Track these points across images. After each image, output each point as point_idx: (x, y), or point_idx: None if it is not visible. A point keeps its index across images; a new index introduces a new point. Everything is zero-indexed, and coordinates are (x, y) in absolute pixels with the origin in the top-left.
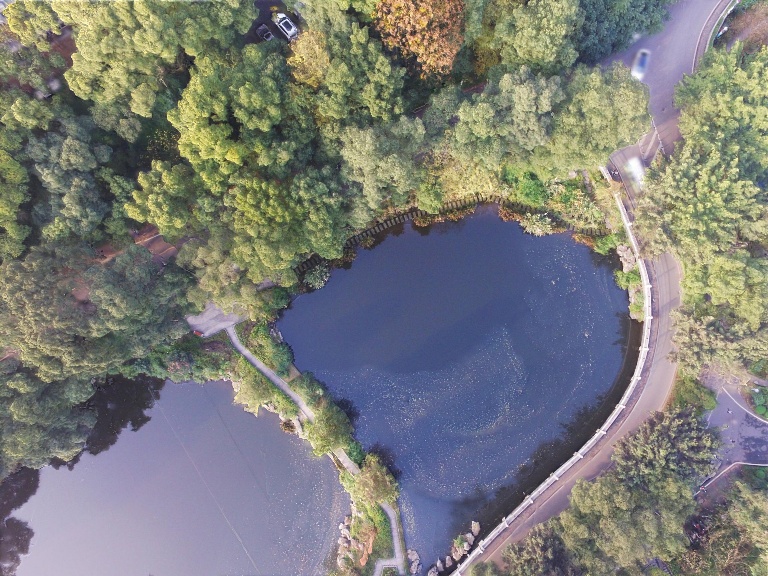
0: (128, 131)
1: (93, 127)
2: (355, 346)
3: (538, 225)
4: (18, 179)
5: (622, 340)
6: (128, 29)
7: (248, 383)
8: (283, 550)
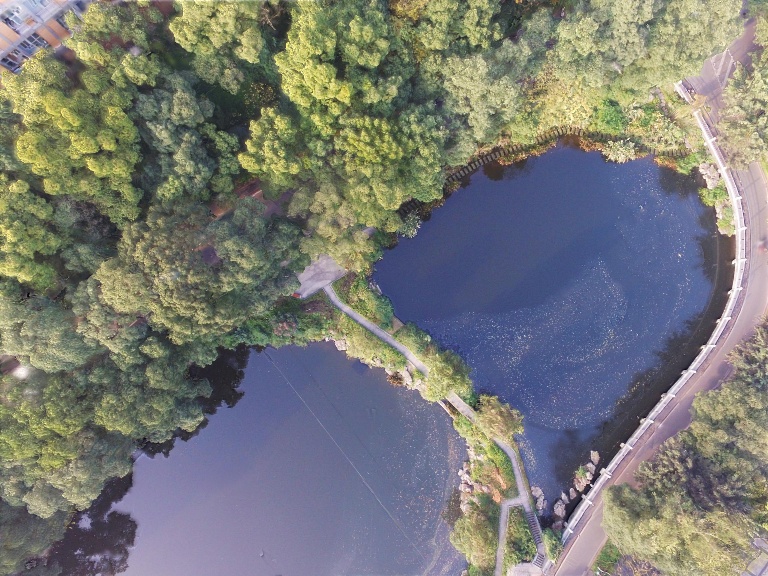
0: (233, 82)
1: (195, 82)
2: (454, 291)
3: (622, 151)
4: (131, 138)
5: (704, 262)
6: None
7: (361, 334)
8: (405, 503)
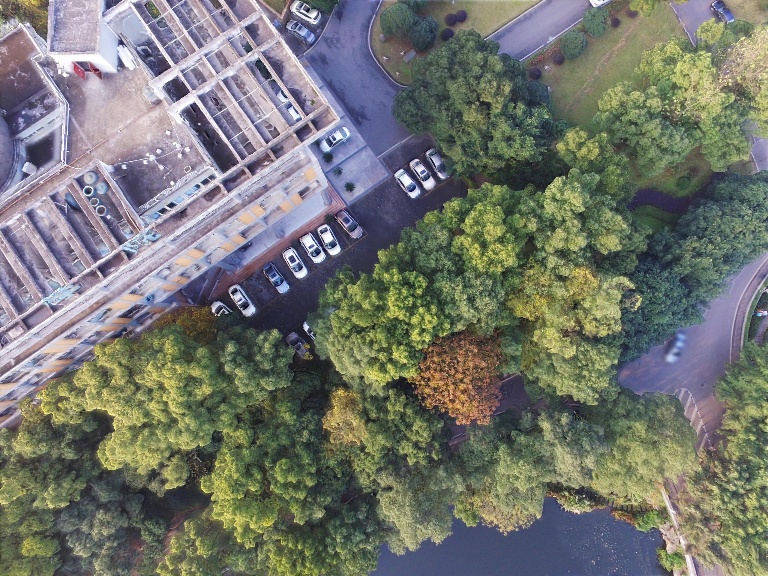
0: (160, 489)
1: (125, 480)
2: None
3: (576, 507)
4: (49, 555)
5: None
6: (163, 422)
7: None
8: None
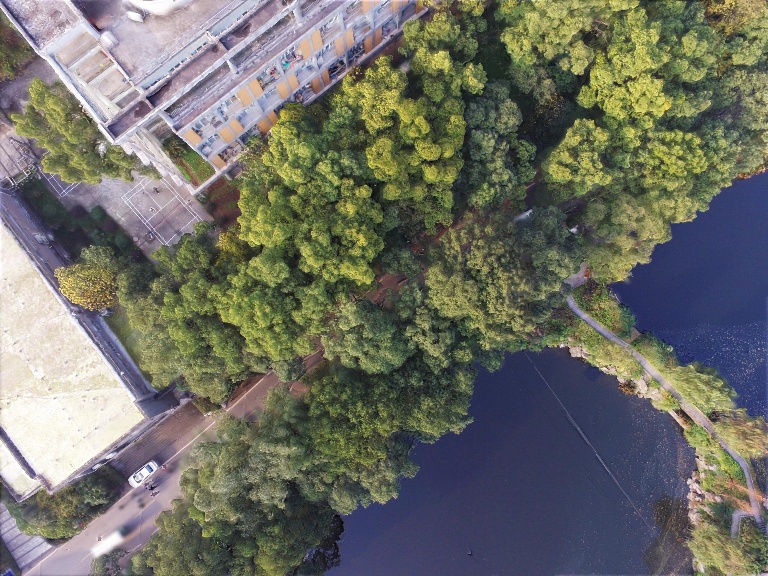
0: (547, 92)
1: None
2: (690, 302)
3: None
4: (460, 146)
5: None
6: None
7: None
8: None
